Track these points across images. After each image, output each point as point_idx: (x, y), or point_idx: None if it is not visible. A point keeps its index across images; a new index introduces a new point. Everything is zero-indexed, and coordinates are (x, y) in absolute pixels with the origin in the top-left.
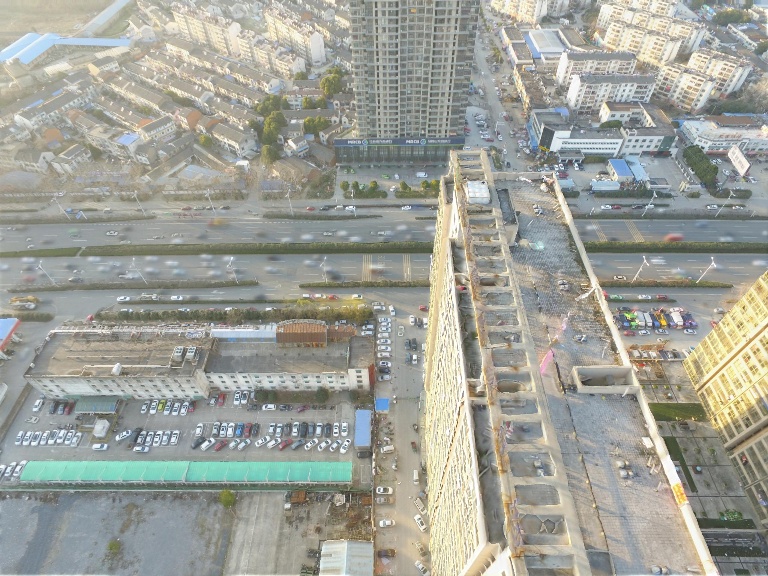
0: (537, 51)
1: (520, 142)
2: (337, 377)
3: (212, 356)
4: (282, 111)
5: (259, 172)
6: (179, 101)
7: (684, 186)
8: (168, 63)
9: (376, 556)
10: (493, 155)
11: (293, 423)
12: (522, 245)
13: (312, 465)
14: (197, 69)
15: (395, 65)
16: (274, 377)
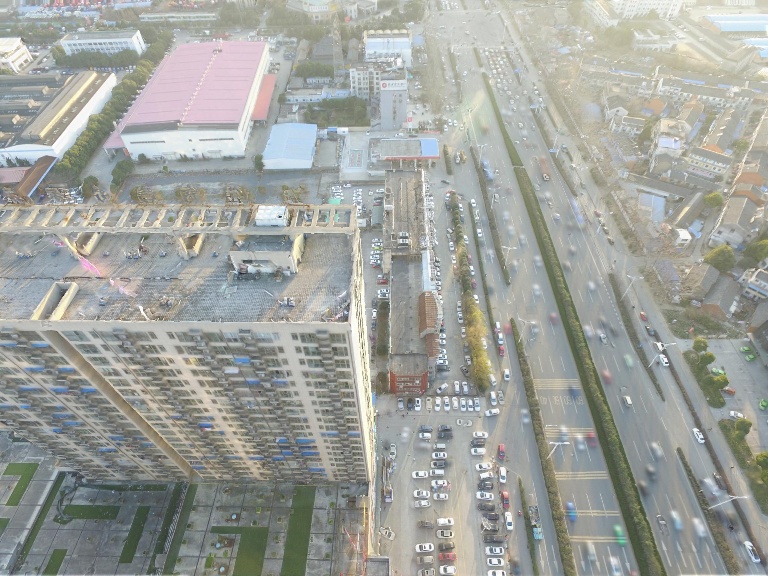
0: None
1: None
2: None
3: None
4: None
5: None
6: None
7: None
8: None
9: None
10: None
11: None
12: None
13: None
14: None
15: None
16: None
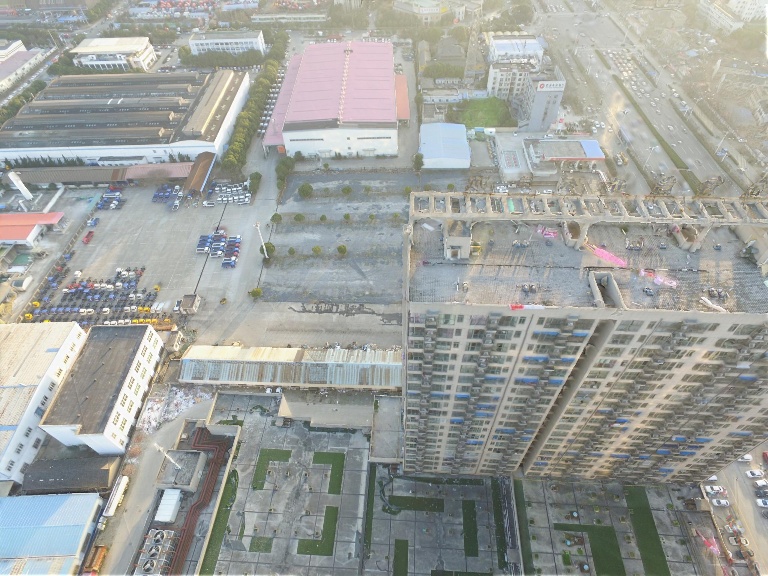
0: None
1: None
2: None
3: None
4: None
5: None
6: None
7: None
8: None
9: None
10: None
11: None
12: None
13: None
14: None
15: None
16: None
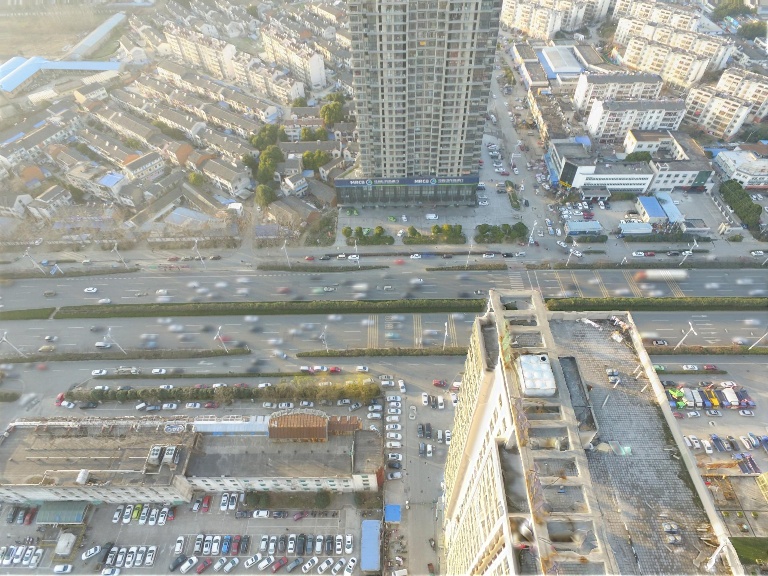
0: (552, 71)
1: (538, 176)
2: (340, 481)
3: (195, 454)
4: (279, 144)
5: (254, 214)
6: (169, 133)
7: (724, 228)
8: (158, 89)
9: None
10: (509, 192)
11: (289, 536)
12: (601, 451)
13: None
14: (189, 96)
15: (402, 102)
16: (266, 481)
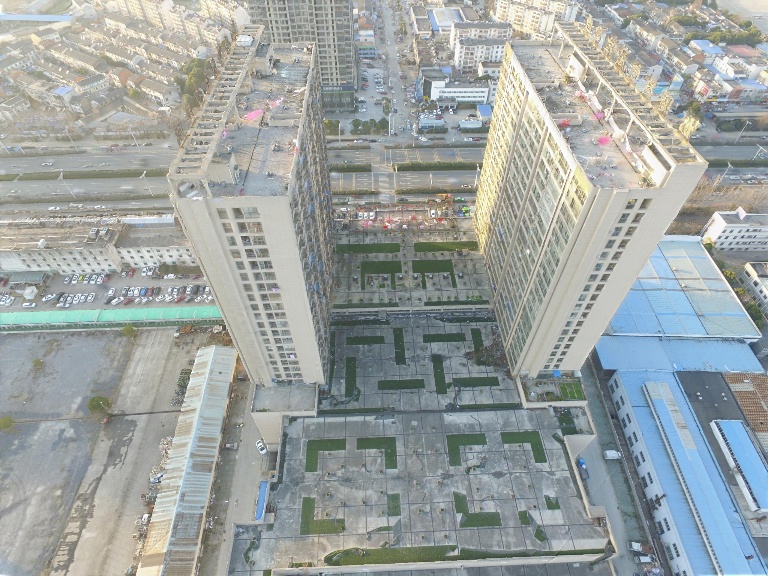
0: (437, 25)
1: (409, 94)
2: None
3: (123, 237)
4: (204, 70)
5: (181, 118)
6: (113, 64)
7: None
8: (106, 34)
9: (240, 360)
10: (384, 104)
11: (188, 286)
12: (273, 73)
13: (198, 308)
14: (132, 38)
15: (285, 20)
16: (172, 251)
